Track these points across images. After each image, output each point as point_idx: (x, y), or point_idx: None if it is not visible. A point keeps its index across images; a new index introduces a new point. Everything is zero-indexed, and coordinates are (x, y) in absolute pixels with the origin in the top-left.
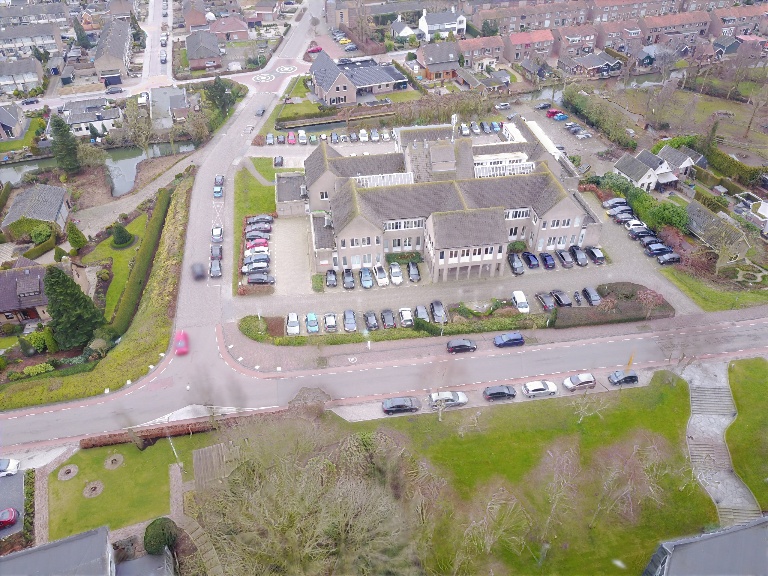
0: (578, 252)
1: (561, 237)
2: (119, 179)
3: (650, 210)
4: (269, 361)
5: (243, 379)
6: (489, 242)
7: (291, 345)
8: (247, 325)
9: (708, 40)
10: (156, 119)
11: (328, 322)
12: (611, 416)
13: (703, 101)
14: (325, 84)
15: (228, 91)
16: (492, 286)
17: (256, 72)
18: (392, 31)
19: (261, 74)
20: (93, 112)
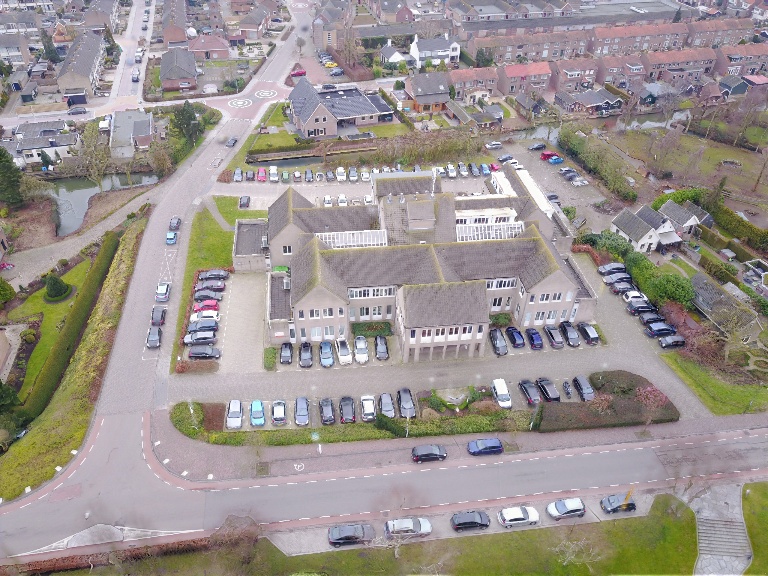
0: (569, 330)
1: (551, 311)
2: (67, 215)
3: (651, 281)
4: (200, 465)
5: (165, 490)
6: (468, 321)
7: (228, 444)
8: (180, 415)
9: (713, 79)
10: (115, 147)
11: (276, 414)
12: (602, 557)
13: (708, 147)
14: (303, 114)
15: (200, 116)
16: (470, 369)
17: (233, 96)
18: (381, 56)
19: (238, 98)
20: (47, 137)
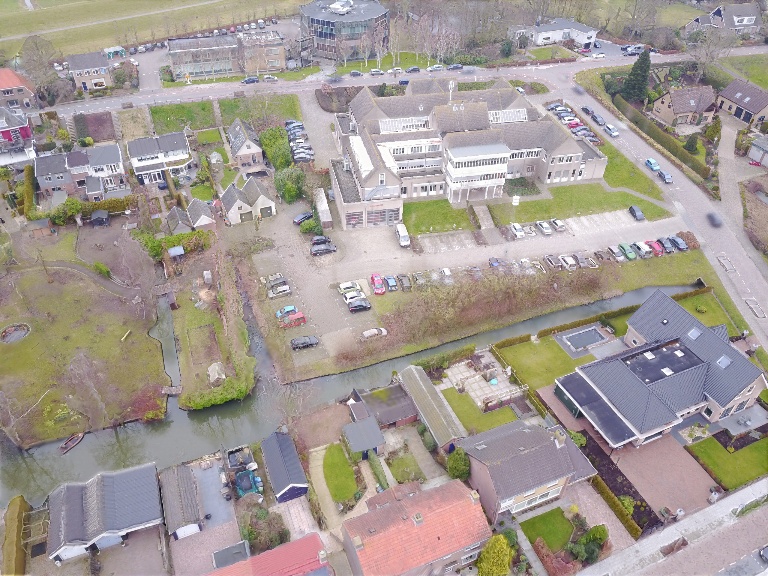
0: None
1: None
2: None
3: None
4: None
5: None
6: None
7: None
8: (542, 85)
9: None
10: None
11: None
12: None
13: (3, 375)
14: None
15: None
16: None
17: None
18: None
19: None
20: None
